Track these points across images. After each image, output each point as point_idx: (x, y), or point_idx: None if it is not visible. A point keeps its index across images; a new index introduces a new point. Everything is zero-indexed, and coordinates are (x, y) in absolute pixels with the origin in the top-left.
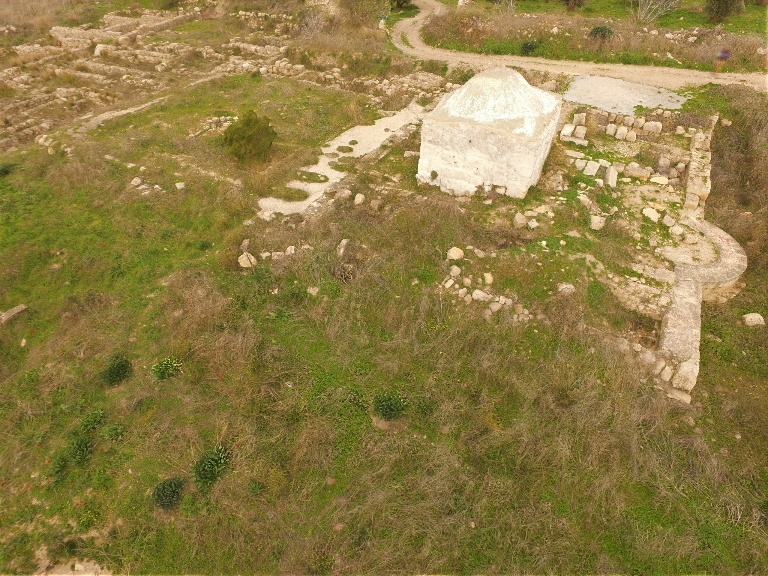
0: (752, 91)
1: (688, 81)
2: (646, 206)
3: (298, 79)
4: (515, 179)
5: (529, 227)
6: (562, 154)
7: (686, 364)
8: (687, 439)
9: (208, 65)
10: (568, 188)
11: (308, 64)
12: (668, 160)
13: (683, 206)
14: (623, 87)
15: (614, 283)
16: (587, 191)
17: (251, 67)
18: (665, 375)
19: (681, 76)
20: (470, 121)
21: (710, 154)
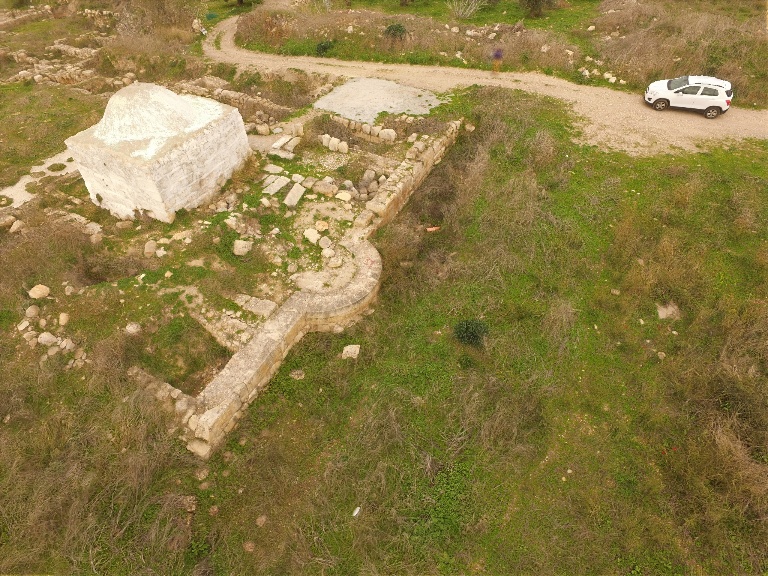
0: (508, 93)
1: (462, 82)
2: (311, 226)
3: (74, 87)
4: (154, 204)
5: (157, 256)
6: (253, 170)
7: (206, 413)
8: (164, 500)
9: (16, 70)
10: (233, 209)
11: (109, 68)
12: (373, 172)
13: (354, 225)
14: (387, 90)
15: (203, 318)
16: (242, 213)
17: (27, 75)
18: (190, 424)
19: (459, 76)
20: (99, 143)
21: (419, 165)
